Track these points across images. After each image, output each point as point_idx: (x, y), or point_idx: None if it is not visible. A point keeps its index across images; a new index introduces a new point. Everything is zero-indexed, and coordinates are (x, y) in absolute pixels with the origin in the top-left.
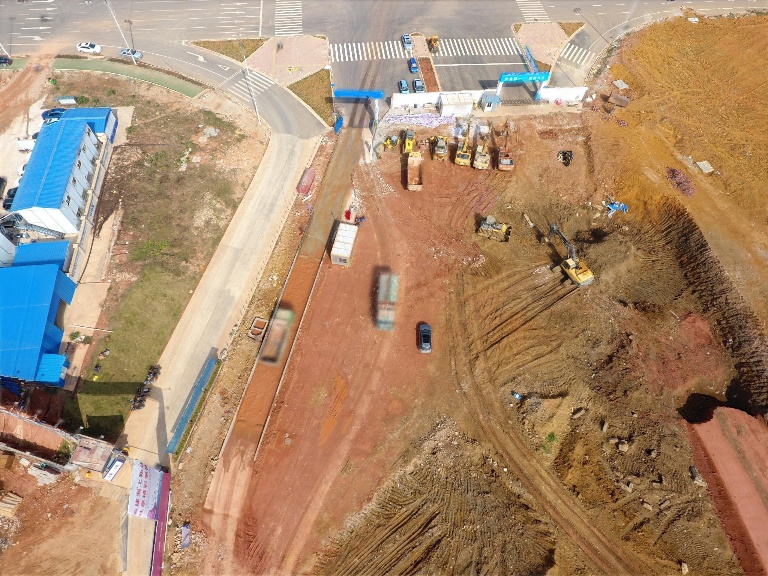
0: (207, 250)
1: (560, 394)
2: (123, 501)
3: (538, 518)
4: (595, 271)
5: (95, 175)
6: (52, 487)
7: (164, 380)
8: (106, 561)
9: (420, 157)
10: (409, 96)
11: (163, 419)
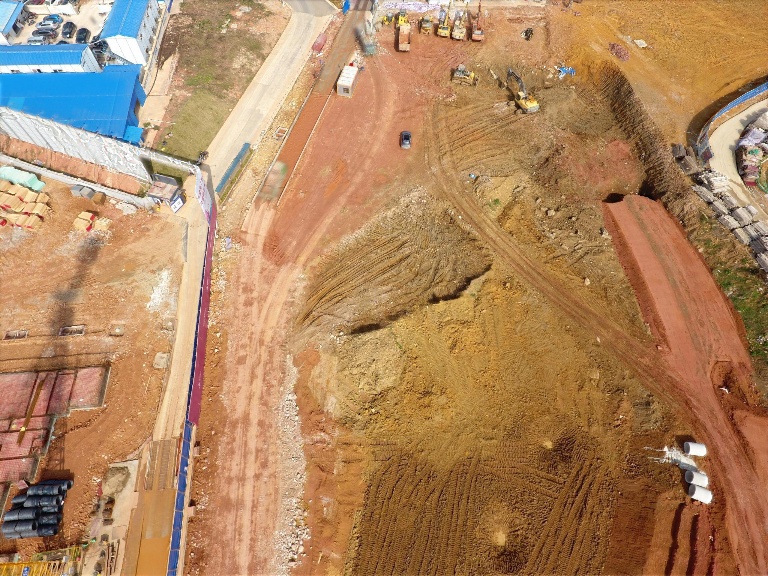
0: (242, 85)
1: (505, 176)
2: (184, 225)
3: (482, 245)
4: (542, 105)
5: (158, 28)
6: (133, 216)
7: (211, 160)
8: (173, 256)
9: (409, 26)
10: None
11: (211, 182)
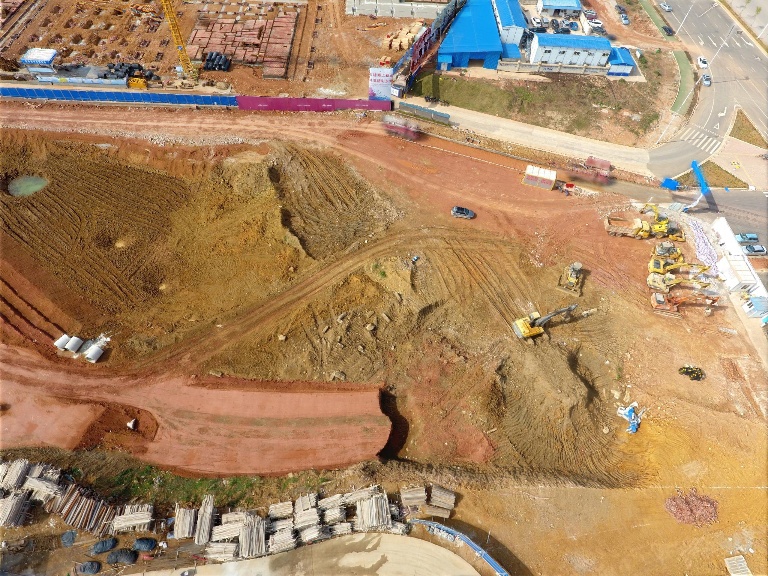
0: (529, 120)
1: (414, 286)
2: None
3: None
4: (533, 349)
5: (574, 65)
6: None
7: (441, 108)
8: (356, 95)
9: (642, 226)
10: (728, 231)
11: None
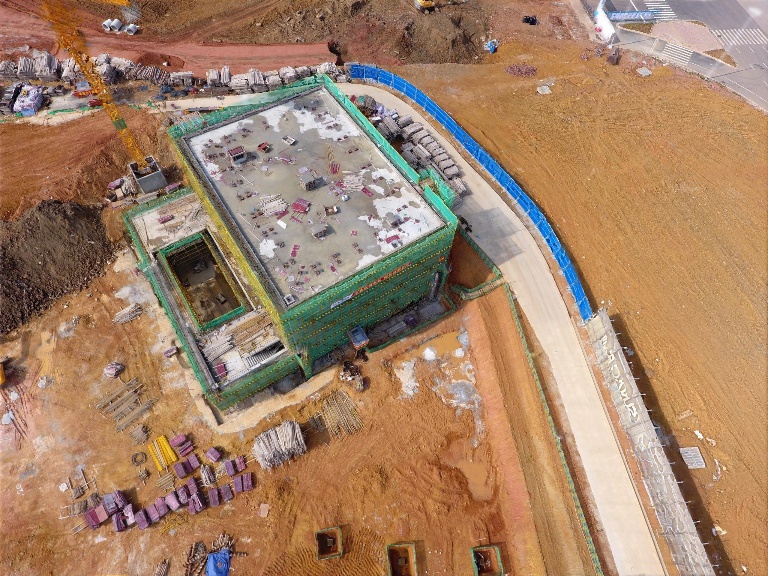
0: None
1: None
2: None
3: None
4: None
5: None
6: None
7: None
8: None
9: None
10: None
11: None
